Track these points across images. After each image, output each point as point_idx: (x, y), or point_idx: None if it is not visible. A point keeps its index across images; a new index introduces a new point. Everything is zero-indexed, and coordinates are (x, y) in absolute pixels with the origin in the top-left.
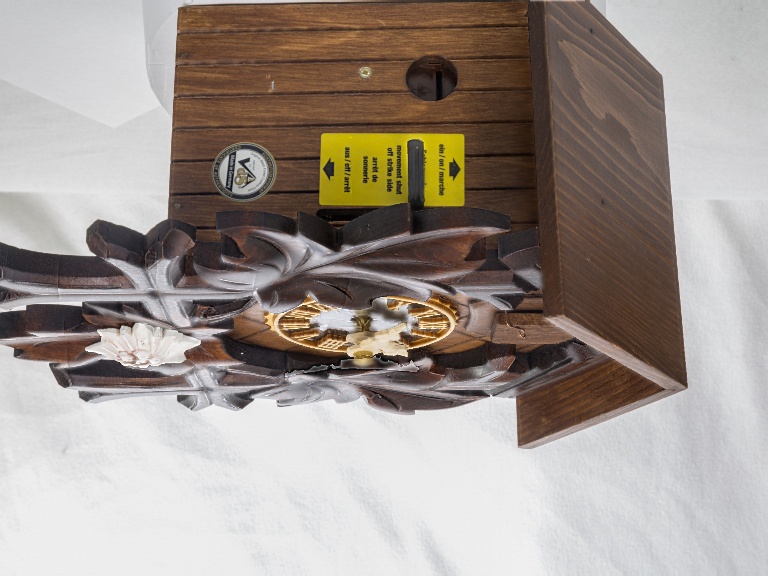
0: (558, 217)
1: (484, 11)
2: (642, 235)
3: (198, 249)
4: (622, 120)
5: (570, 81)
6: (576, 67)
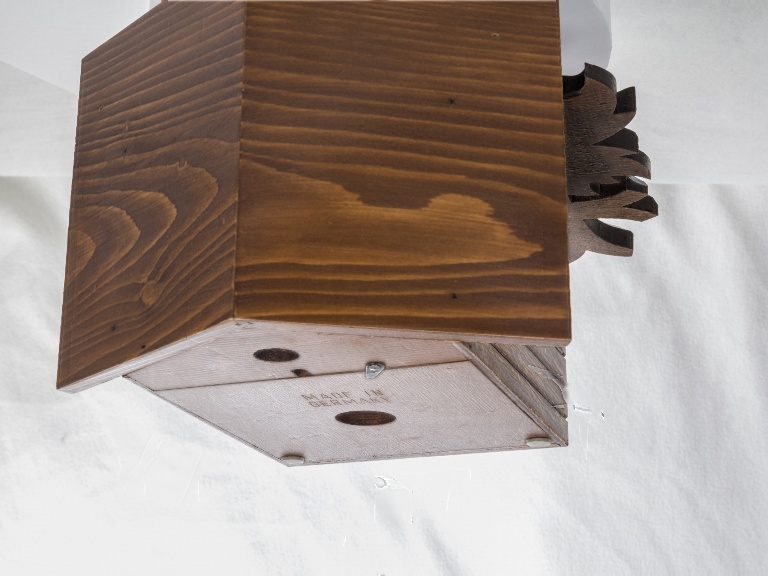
0: (559, 61)
1: (489, 358)
2: (347, 90)
3: (598, 187)
4: (381, 213)
5: (518, 213)
6: (500, 236)
